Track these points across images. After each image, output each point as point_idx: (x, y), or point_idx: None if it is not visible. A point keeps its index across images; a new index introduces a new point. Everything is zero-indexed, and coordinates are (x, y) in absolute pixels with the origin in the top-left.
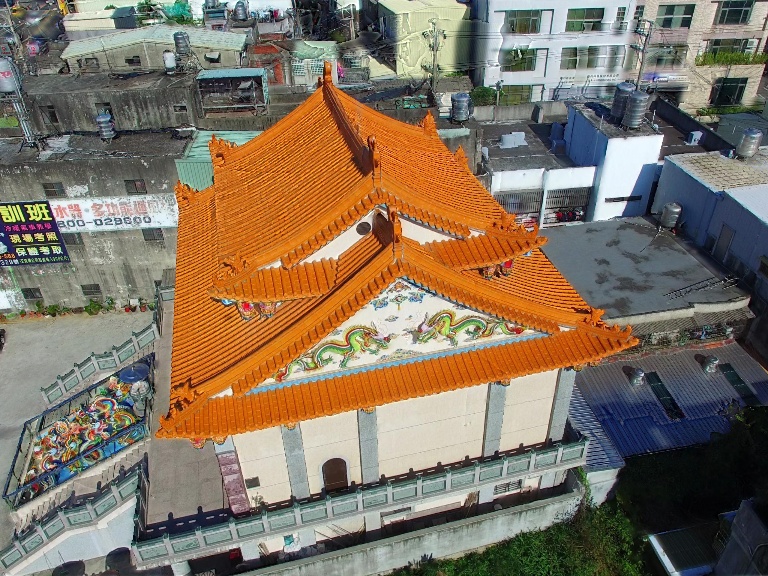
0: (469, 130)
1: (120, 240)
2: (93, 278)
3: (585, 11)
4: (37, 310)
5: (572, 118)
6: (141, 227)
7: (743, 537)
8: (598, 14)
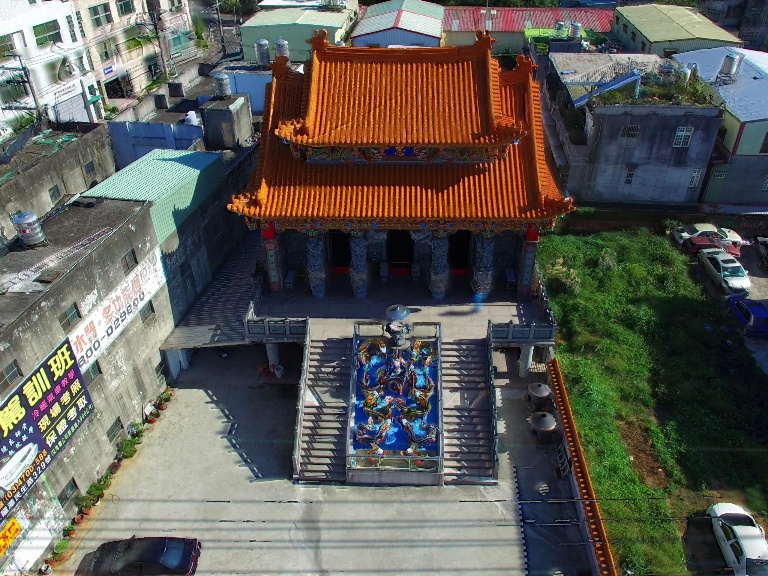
0: (243, 98)
1: (127, 340)
2: (114, 413)
3: (44, 26)
4: (76, 513)
5: (232, 80)
6: (139, 310)
7: (578, 160)
8: (54, 26)
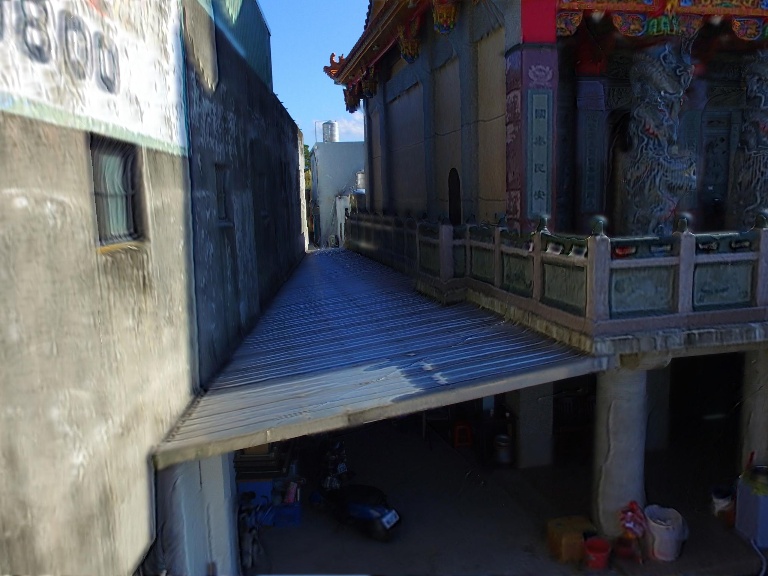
0: None
1: None
2: None
3: None
4: None
5: None
6: (88, 115)
7: None
8: None
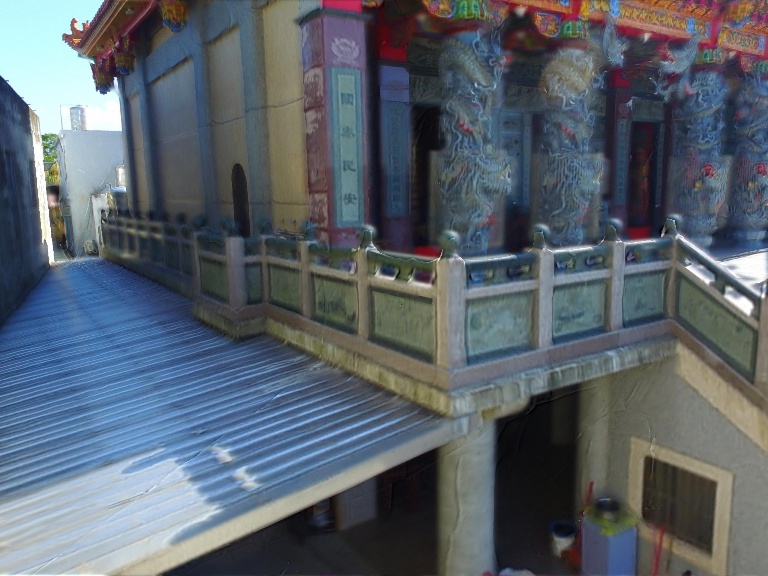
0: None
1: None
2: None
3: None
4: None
5: None
6: None
7: None
8: None
